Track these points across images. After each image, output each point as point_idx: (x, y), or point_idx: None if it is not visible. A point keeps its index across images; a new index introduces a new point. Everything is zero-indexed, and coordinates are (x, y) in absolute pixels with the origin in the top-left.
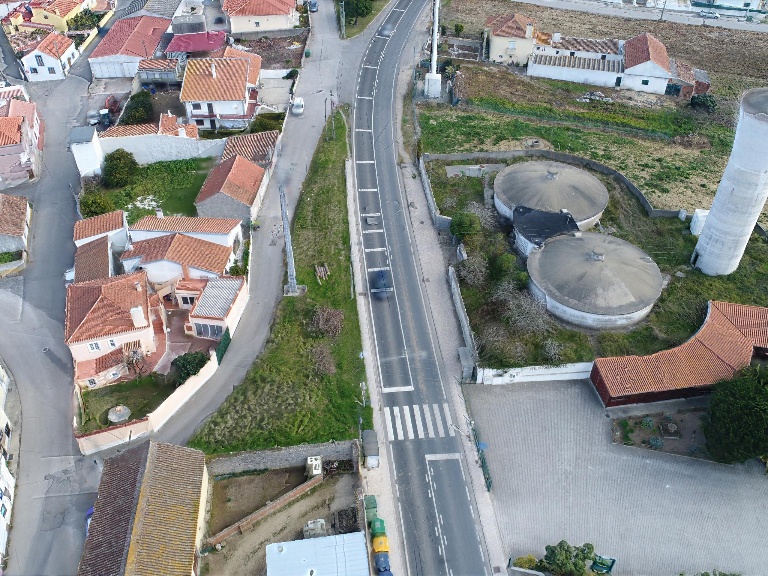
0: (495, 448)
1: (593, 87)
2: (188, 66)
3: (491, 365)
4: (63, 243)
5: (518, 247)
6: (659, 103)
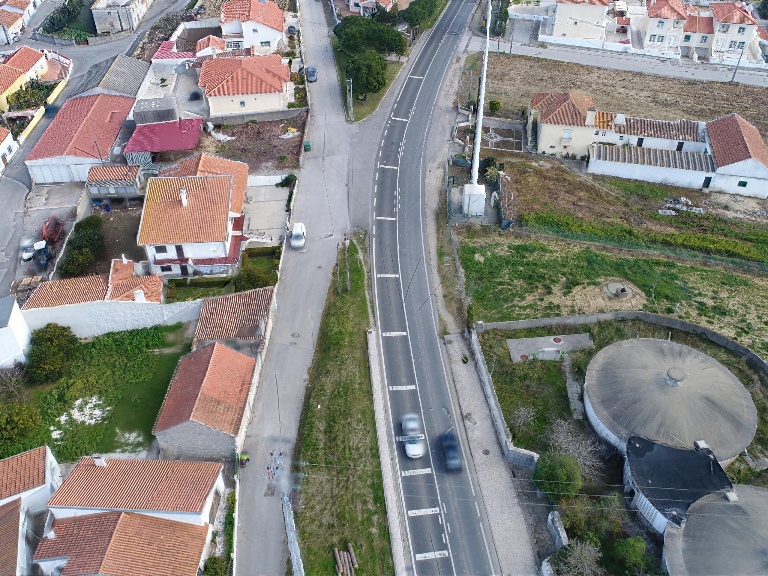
0: None
1: (675, 190)
2: (149, 189)
3: None
4: None
5: (637, 507)
6: (764, 214)
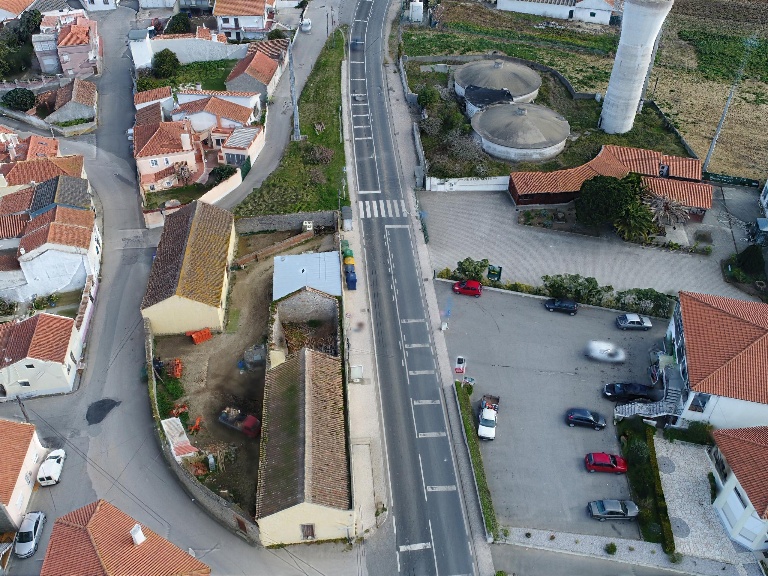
0: (434, 223)
1: (550, 18)
2: None
3: (436, 175)
4: (124, 114)
5: (468, 114)
6: (602, 30)
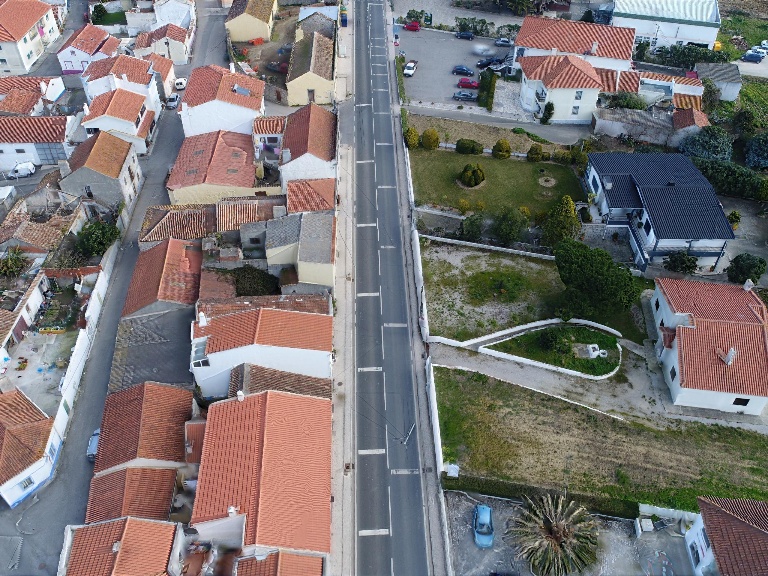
0: (399, 4)
1: None
2: None
3: None
4: None
5: None
6: None
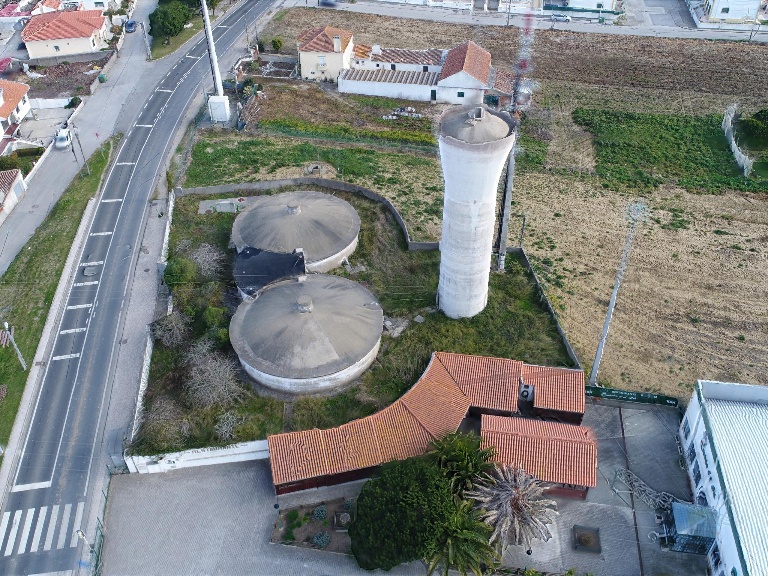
0: (119, 560)
1: (406, 102)
2: None
3: (140, 452)
4: None
5: (241, 295)
6: None
